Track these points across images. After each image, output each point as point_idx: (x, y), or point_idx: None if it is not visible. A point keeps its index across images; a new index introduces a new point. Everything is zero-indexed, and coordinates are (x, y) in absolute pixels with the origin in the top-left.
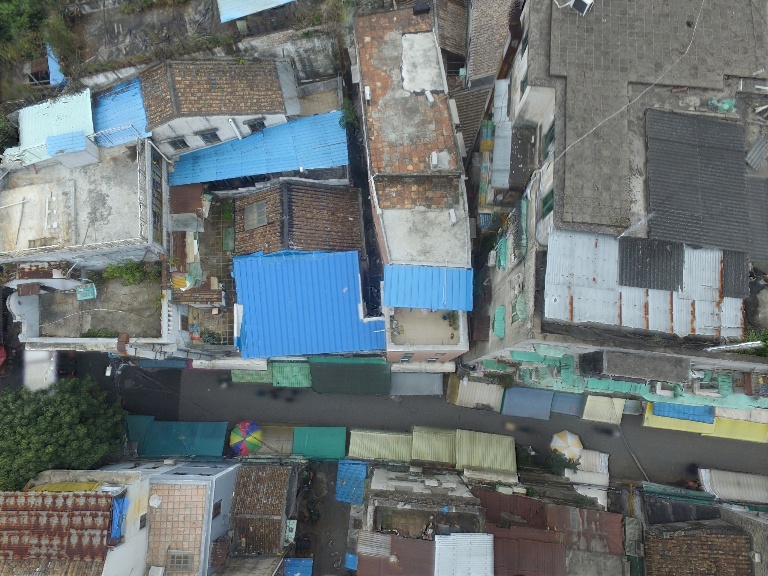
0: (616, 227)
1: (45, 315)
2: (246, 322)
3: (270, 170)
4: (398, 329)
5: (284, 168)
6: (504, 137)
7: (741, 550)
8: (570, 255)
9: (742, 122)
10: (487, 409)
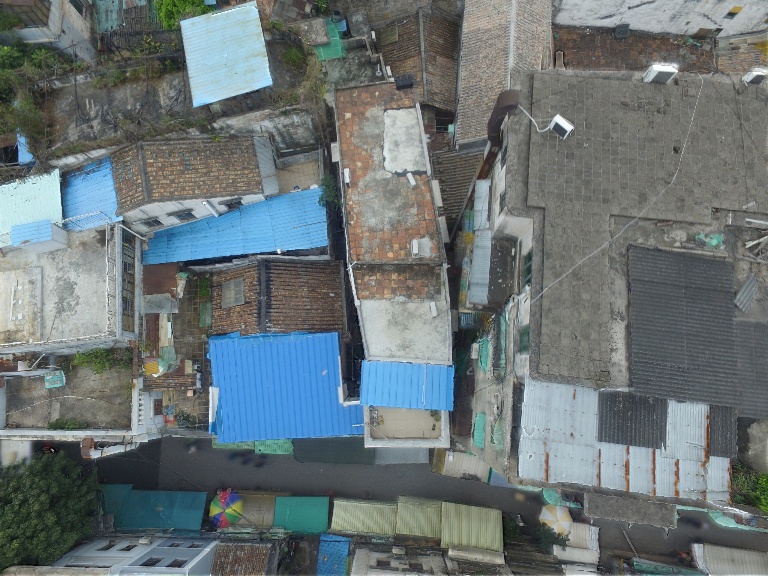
0: (595, 380)
1: (12, 402)
2: (222, 405)
3: (247, 251)
4: (378, 419)
5: (261, 249)
6: (483, 247)
7: None
8: (546, 406)
9: (731, 258)
10: (474, 479)
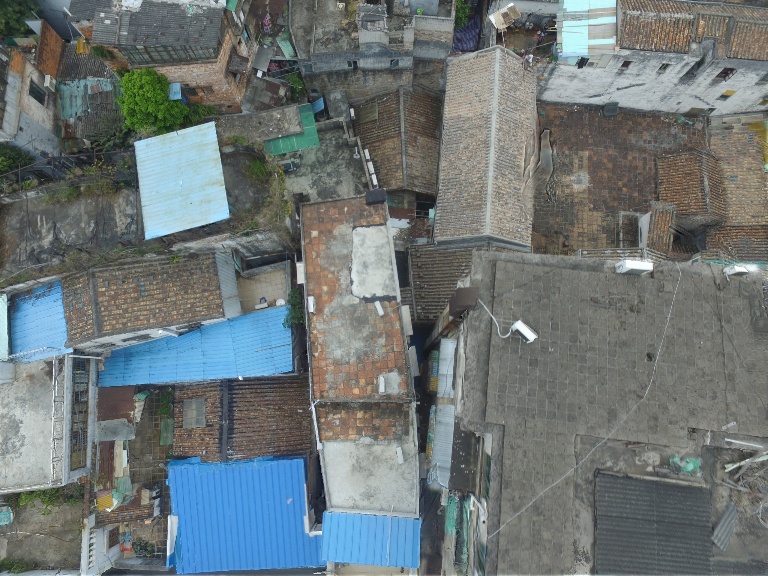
0: None
1: None
2: (181, 534)
3: (207, 376)
4: None
5: (222, 375)
6: (446, 424)
7: None
8: None
9: (709, 483)
10: None
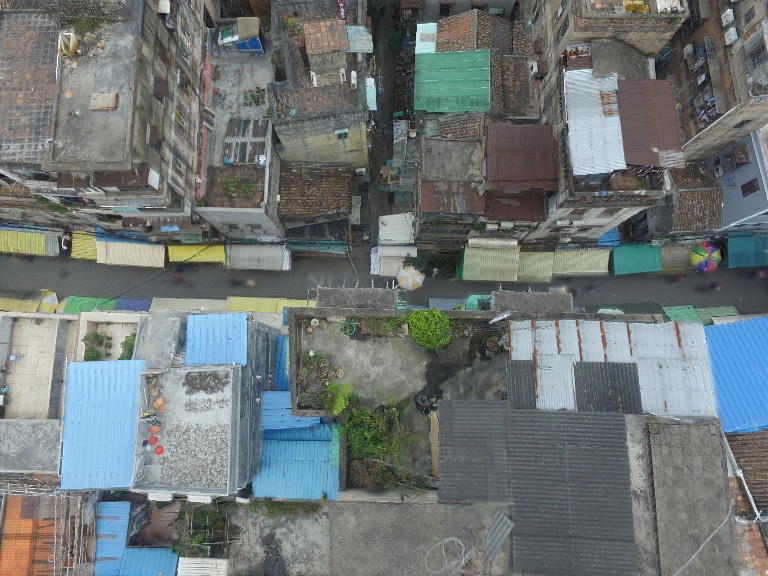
0: None
1: None
2: None
3: None
4: None
5: None
6: None
7: (286, 203)
8: None
9: None
10: None
